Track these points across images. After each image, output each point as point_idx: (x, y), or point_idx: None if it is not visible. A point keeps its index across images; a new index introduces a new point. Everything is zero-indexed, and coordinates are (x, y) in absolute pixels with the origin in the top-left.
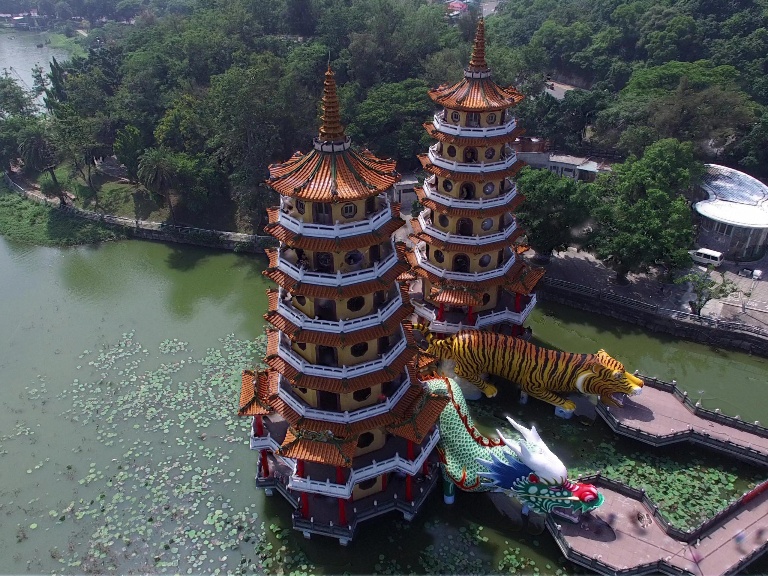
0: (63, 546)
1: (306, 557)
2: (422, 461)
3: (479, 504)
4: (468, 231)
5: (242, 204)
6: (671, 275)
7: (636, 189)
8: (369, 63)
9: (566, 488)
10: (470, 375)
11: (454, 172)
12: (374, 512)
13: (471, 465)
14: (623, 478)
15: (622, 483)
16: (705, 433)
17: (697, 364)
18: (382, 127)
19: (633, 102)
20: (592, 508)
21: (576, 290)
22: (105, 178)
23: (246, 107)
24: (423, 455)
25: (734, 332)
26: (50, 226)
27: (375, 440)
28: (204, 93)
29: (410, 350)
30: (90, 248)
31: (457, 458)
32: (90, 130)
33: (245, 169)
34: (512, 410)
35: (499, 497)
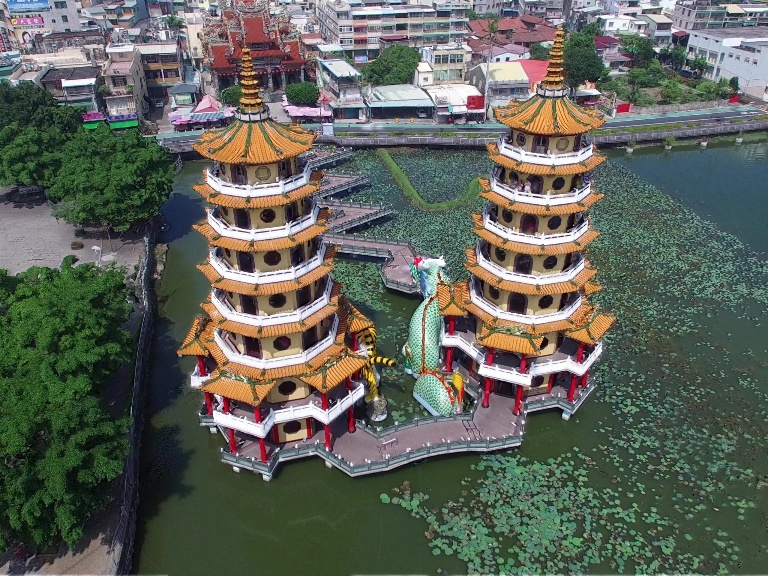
0: (762, 454)
1: None
2: None
3: None
4: None
5: None
6: None
7: None
8: None
9: None
10: None
11: None
12: None
13: None
14: (359, 293)
15: None
16: None
17: None
18: None
19: None
20: None
21: None
22: None
23: None
24: None
25: None
26: None
27: None
28: None
29: None
30: None
31: None
32: None
33: None
34: None
35: None
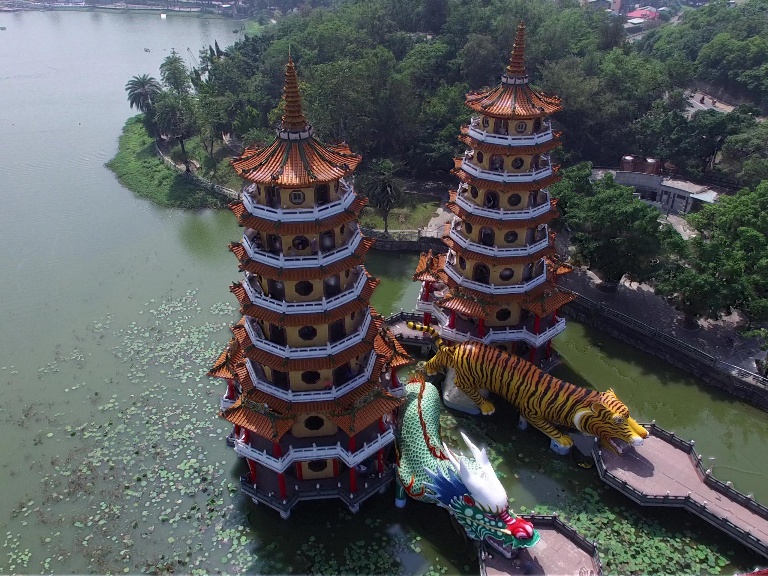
0: (63, 457)
1: (247, 520)
2: (365, 456)
3: (433, 516)
4: (490, 241)
5: None
6: (754, 328)
7: (734, 226)
8: (483, 65)
9: (502, 519)
10: (467, 387)
11: (476, 178)
12: (317, 494)
13: (420, 473)
14: (593, 529)
15: None
16: (702, 504)
17: (762, 433)
18: None
19: None
20: (522, 546)
21: (631, 325)
22: (229, 152)
23: (338, 98)
24: (366, 450)
25: None
26: (172, 189)
27: (325, 425)
28: None
29: (365, 344)
30: (196, 212)
31: (410, 463)
32: (216, 107)
33: None
34: (507, 433)
35: None
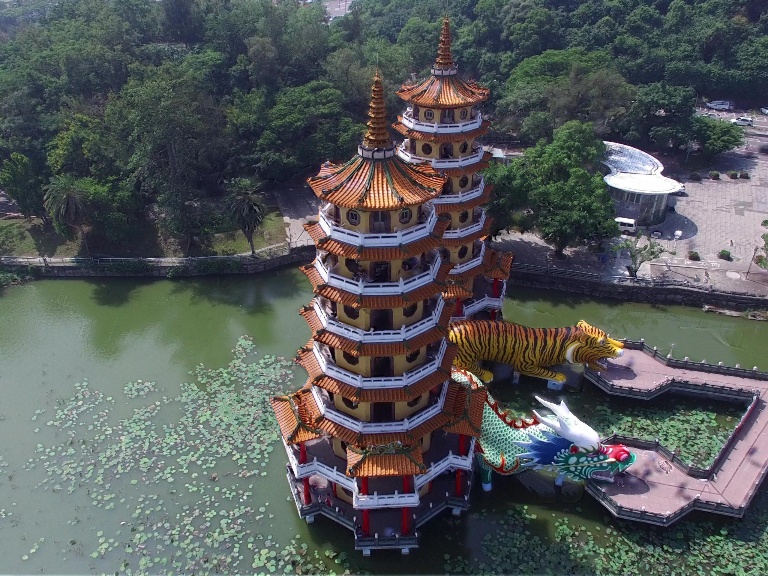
0: None
1: (373, 575)
2: (471, 454)
3: (511, 485)
4: None
5: (171, 226)
6: (599, 245)
7: (555, 170)
8: (271, 68)
9: (601, 452)
10: (468, 364)
11: (434, 169)
12: (429, 514)
13: (508, 449)
14: (627, 434)
15: (637, 438)
16: None
17: (635, 322)
18: (300, 132)
19: (527, 90)
20: (628, 466)
21: (525, 270)
22: None
23: None
24: (472, 448)
25: (668, 288)
26: None
27: (424, 443)
28: (93, 111)
29: (451, 348)
30: None
31: (493, 445)
32: None
33: (172, 188)
34: (509, 391)
35: (528, 475)
